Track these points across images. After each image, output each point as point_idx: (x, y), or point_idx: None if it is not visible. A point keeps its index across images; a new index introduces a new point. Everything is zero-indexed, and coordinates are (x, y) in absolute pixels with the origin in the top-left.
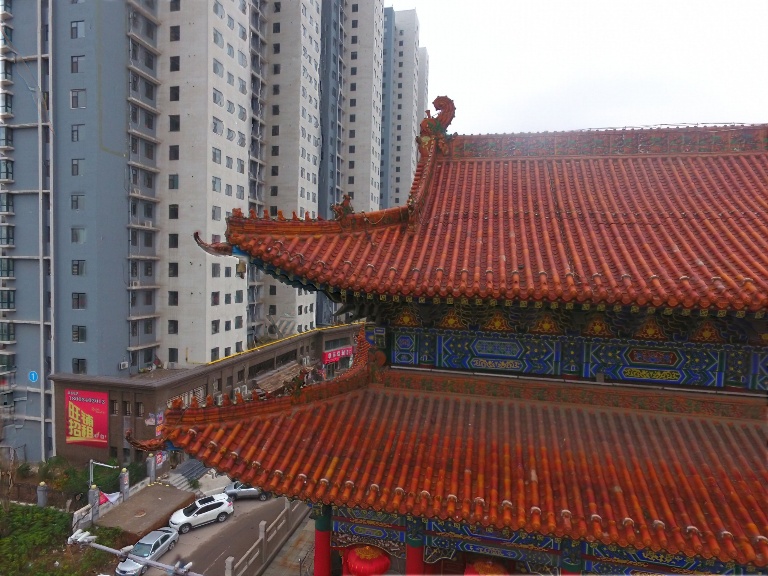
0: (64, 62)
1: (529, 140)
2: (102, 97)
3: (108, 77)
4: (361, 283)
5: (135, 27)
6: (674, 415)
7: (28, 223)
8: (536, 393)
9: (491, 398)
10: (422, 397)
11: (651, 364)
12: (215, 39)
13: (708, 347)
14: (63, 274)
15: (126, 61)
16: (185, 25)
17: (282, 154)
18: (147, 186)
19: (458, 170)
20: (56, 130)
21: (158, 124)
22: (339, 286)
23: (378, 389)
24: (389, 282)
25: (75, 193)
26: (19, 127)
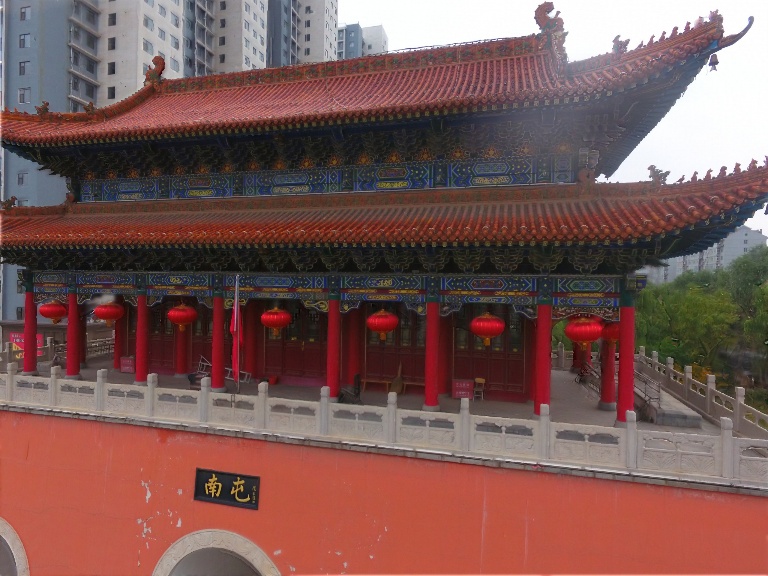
0: (14, 67)
1: (202, 80)
2: (43, 94)
3: (49, 78)
4: (23, 137)
5: (76, 39)
6: (204, 212)
7: None
8: (143, 208)
9: (123, 214)
10: (89, 217)
11: (199, 187)
12: (145, 47)
13: (225, 174)
14: None
15: (67, 66)
16: (119, 37)
17: None
18: None
19: (159, 100)
20: None
21: None
22: (15, 140)
23: (69, 215)
24: (38, 136)
25: (21, 172)
26: None
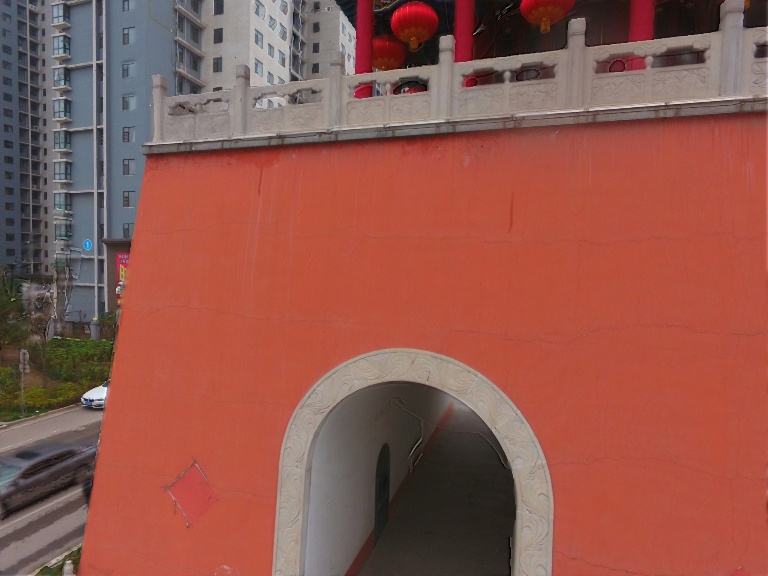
0: None
1: None
2: None
3: None
4: None
5: None
6: None
7: (83, 96)
8: None
9: None
10: None
11: None
12: None
13: None
14: (115, 142)
15: None
16: None
17: (322, 71)
18: (193, 68)
19: None
20: (109, 2)
21: (203, 9)
22: None
23: None
24: None
25: (126, 62)
26: (75, 3)
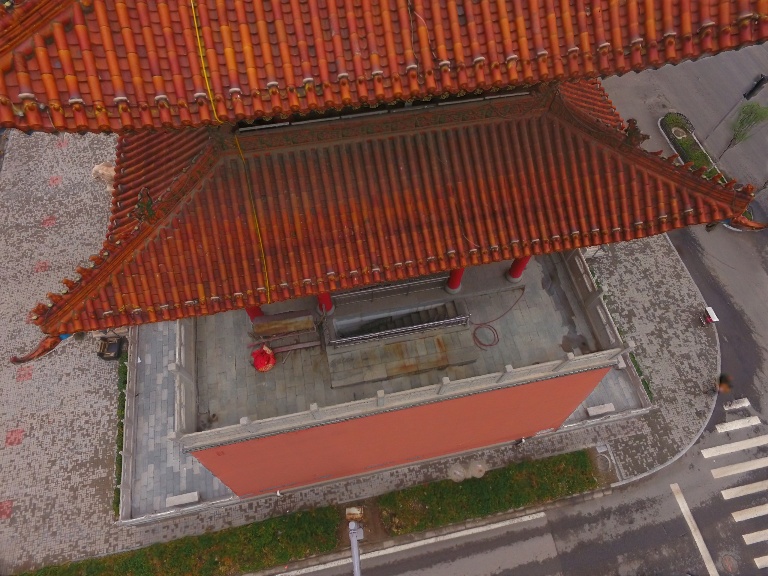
0: None
1: None
2: None
3: None
4: None
5: None
6: None
7: None
8: None
9: None
10: None
11: None
12: None
13: None
14: None
15: None
16: None
17: None
18: None
19: None
20: None
21: None
22: None
23: None
24: None
25: None
26: None
